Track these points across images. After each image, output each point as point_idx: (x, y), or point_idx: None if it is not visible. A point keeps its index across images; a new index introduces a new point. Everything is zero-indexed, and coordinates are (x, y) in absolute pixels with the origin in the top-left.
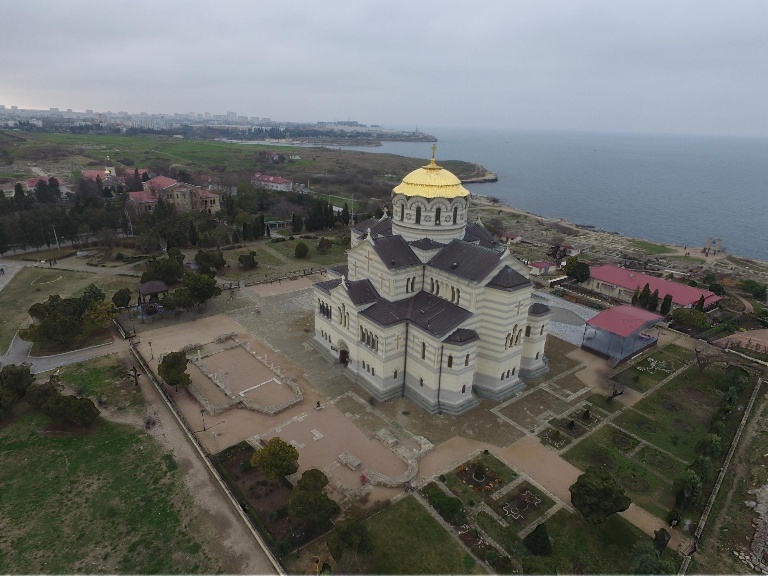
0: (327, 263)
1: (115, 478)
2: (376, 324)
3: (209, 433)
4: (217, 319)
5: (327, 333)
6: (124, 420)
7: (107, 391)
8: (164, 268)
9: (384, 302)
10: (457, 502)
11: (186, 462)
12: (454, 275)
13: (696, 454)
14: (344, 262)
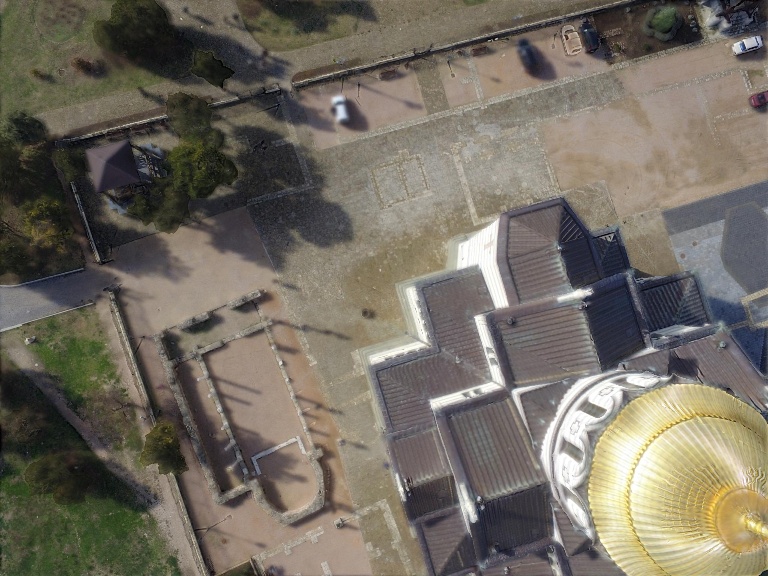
0: None
1: (126, 575)
2: None
3: (213, 535)
4: (234, 227)
5: None
6: (123, 476)
7: (96, 404)
8: (129, 27)
9: (458, 523)
10: None
11: (190, 575)
12: None
13: None
14: None
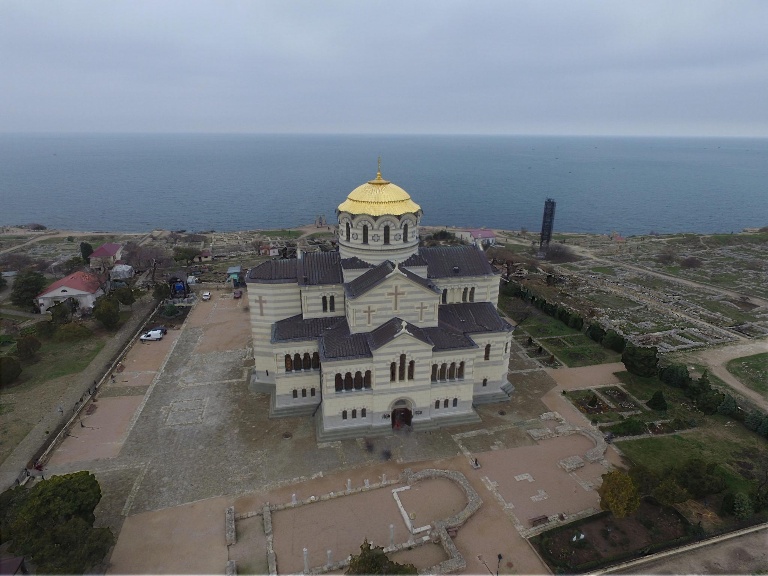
0: (79, 367)
1: None
2: (467, 349)
3: (505, 575)
4: (142, 529)
5: (359, 408)
6: None
7: None
8: None
9: (433, 330)
10: None
11: None
12: (470, 276)
13: (572, 328)
14: (100, 354)
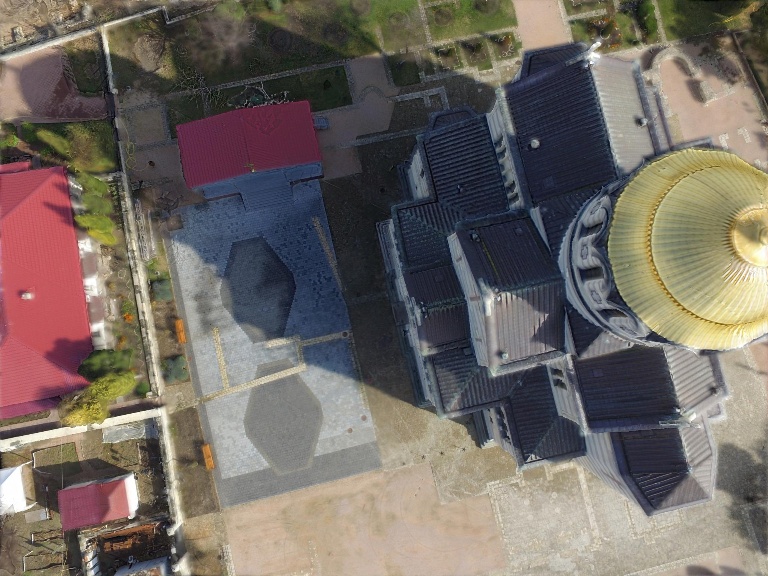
0: None
1: None
2: None
3: None
4: None
5: None
6: None
7: None
8: None
9: None
10: (648, 5)
11: None
12: None
13: None
14: None
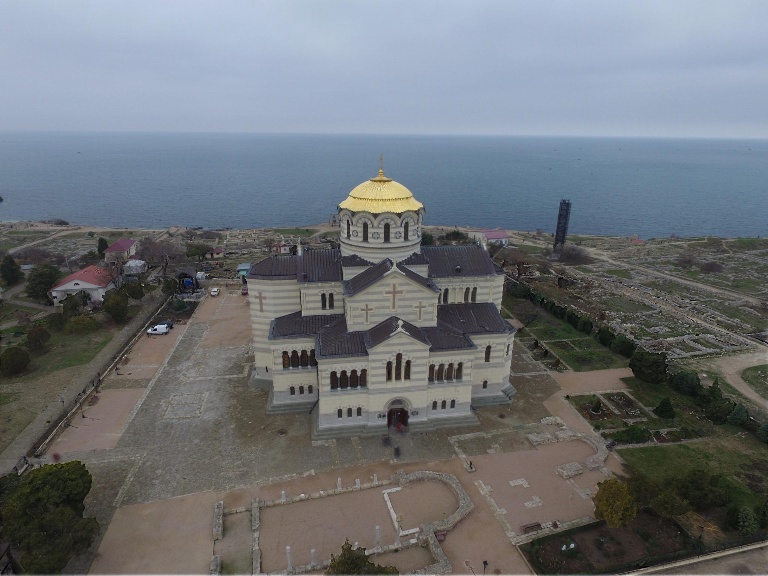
0: (85, 359)
1: None
2: (465, 350)
3: None
4: (131, 520)
5: (354, 407)
6: None
7: None
8: None
9: (431, 330)
10: None
11: None
12: (472, 276)
13: (581, 332)
14: (107, 346)
